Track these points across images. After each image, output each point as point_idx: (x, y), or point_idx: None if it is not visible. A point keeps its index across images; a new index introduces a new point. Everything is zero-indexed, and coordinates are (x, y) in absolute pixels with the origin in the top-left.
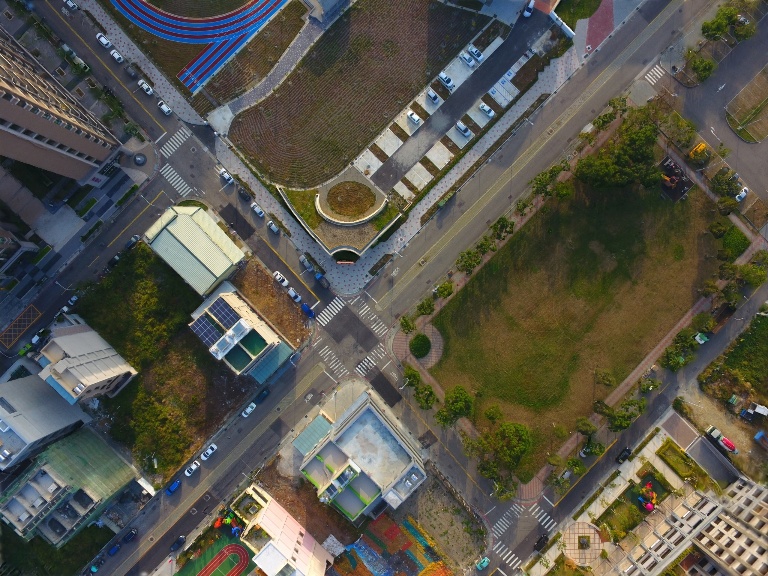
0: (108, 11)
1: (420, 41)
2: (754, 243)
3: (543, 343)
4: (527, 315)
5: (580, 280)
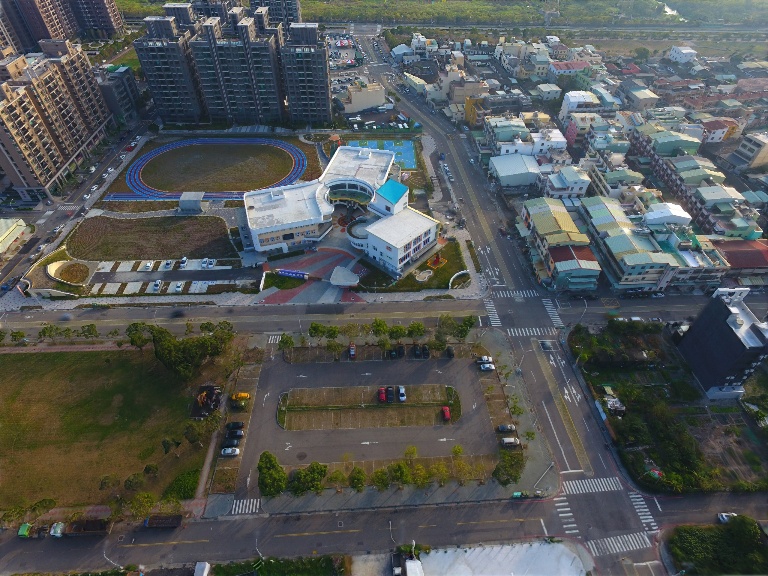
0: None
1: (200, 244)
2: (195, 500)
3: (1, 426)
4: (26, 401)
5: (80, 411)
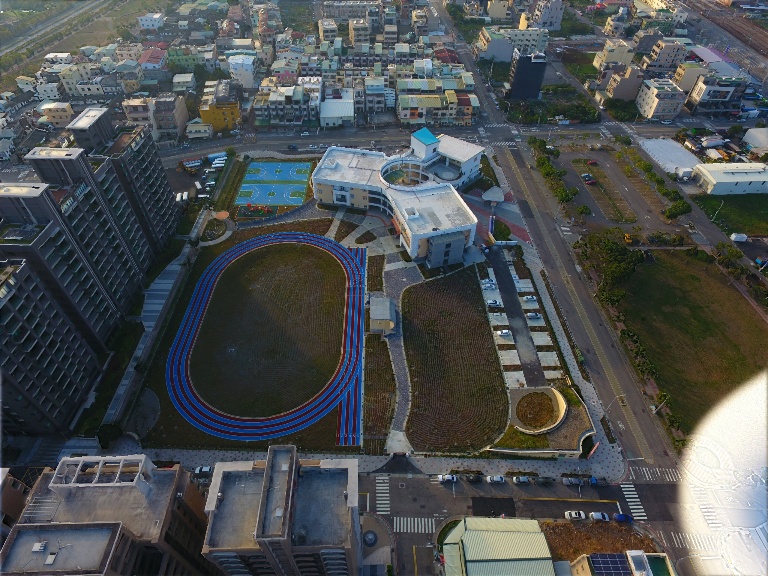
0: (241, 449)
1: (456, 299)
2: (704, 249)
3: (739, 378)
4: (707, 372)
5: (690, 330)
